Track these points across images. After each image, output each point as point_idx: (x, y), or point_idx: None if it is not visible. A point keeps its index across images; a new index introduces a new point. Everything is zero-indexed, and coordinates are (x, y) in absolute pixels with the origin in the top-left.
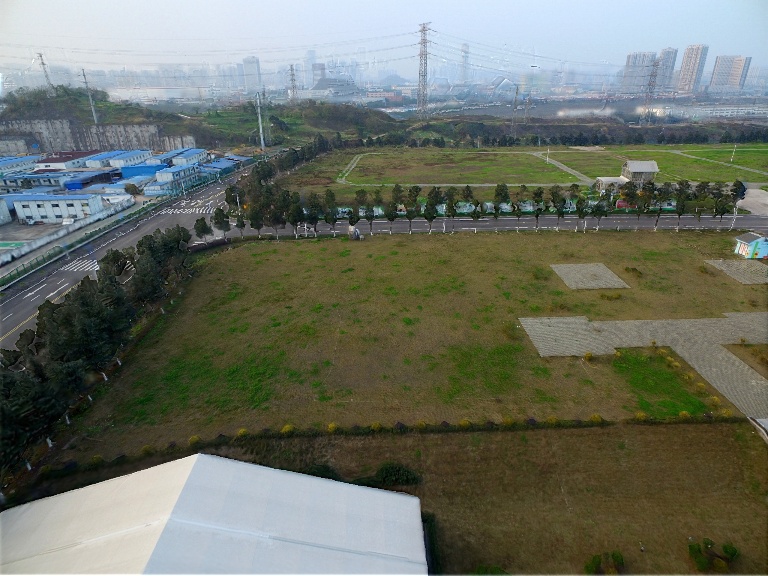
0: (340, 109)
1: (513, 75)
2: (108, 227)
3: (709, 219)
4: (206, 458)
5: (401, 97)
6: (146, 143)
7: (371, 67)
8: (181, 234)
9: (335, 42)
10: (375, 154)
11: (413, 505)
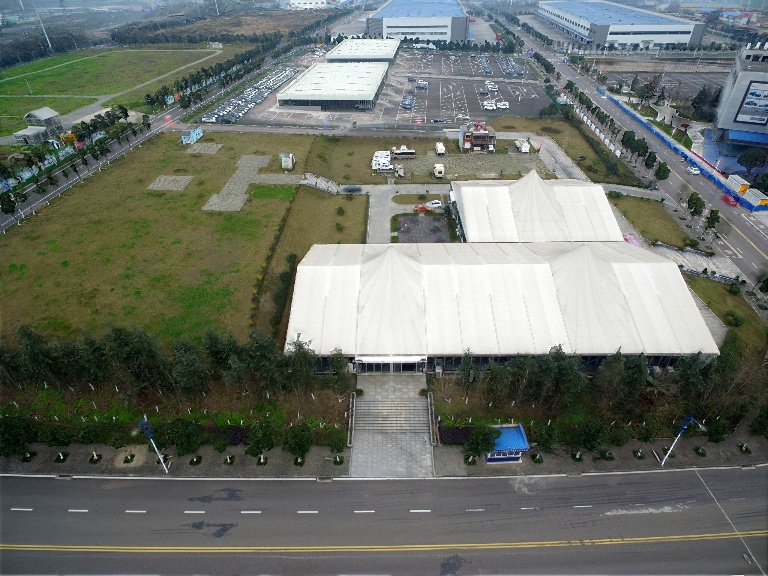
0: None
1: None
2: None
3: None
4: (300, 264)
5: None
6: None
7: None
8: None
9: None
10: None
11: None
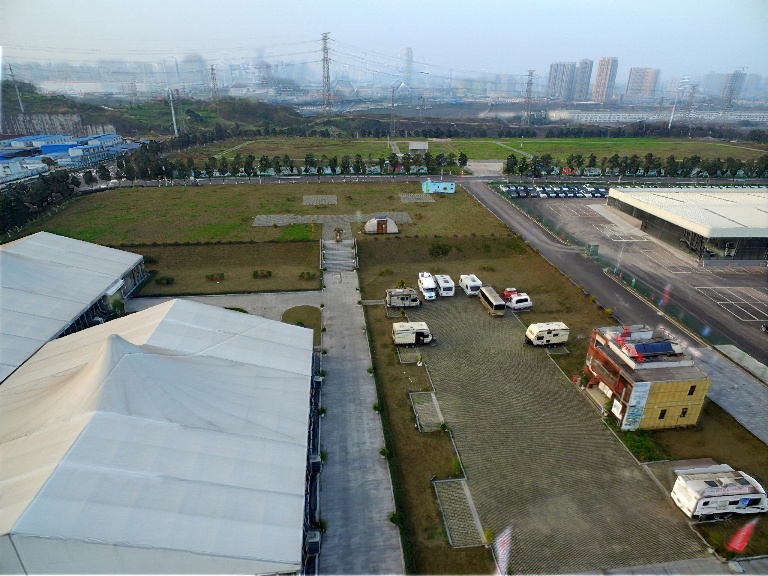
0: (252, 105)
1: (408, 80)
2: (24, 182)
3: (438, 177)
4: None
5: (309, 96)
6: (70, 130)
7: (280, 69)
8: None
9: (246, 47)
10: (263, 141)
11: (138, 256)
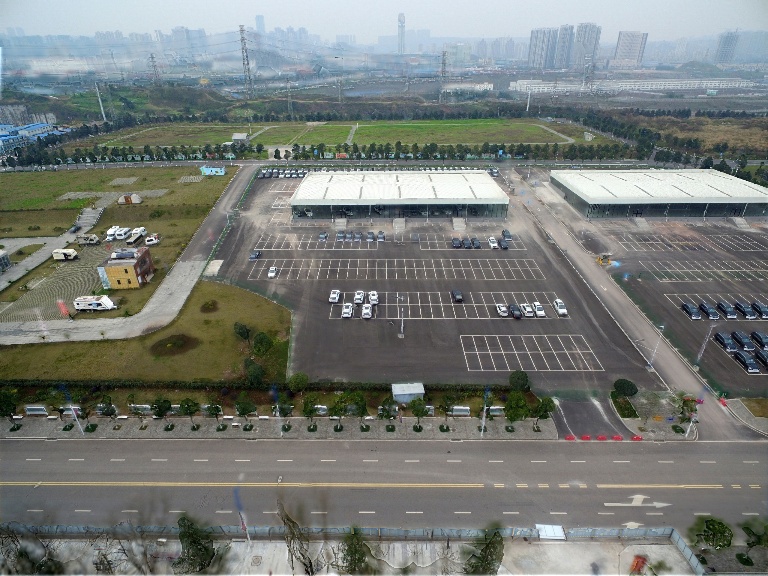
0: (179, 91)
1: (325, 64)
2: None
3: None
4: None
5: (234, 81)
6: (19, 118)
7: (205, 58)
8: None
9: (171, 39)
10: (163, 128)
11: None
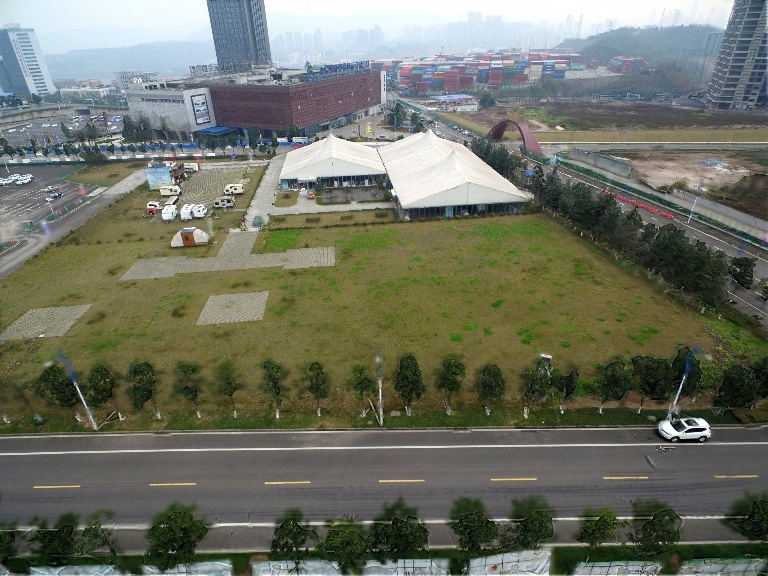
0: None
1: None
2: None
3: None
4: None
5: None
6: None
7: None
8: (715, 269)
9: None
10: None
11: None
